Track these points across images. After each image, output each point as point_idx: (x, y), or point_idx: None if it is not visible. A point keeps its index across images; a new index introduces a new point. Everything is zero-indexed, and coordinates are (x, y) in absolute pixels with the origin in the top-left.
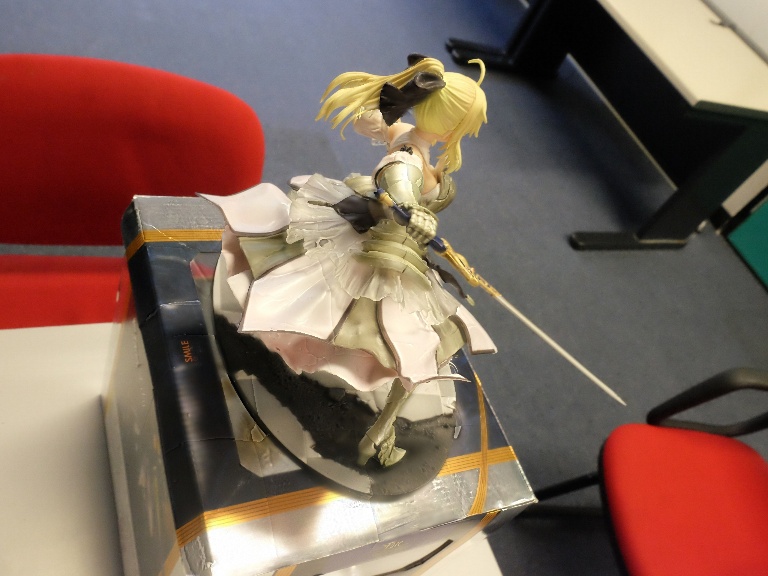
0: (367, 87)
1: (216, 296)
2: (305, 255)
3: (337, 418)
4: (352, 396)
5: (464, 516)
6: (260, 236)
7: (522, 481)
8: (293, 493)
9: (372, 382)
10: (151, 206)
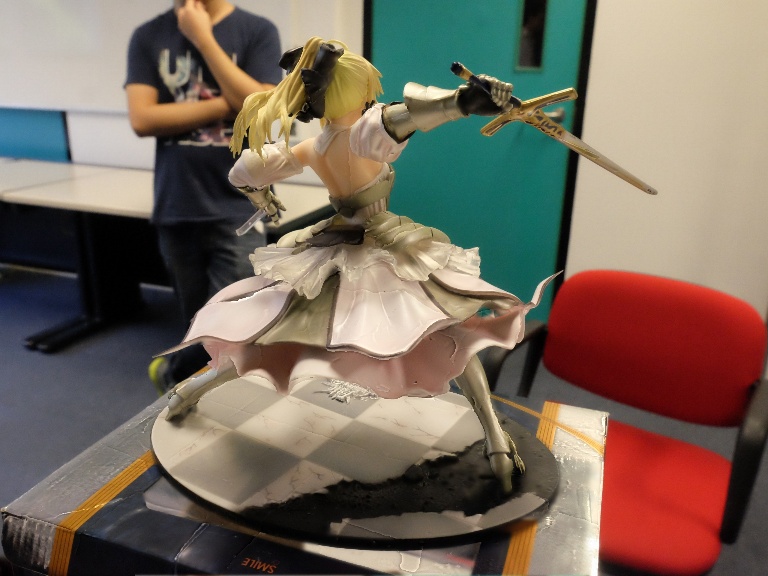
0: (278, 95)
1: (217, 501)
2: (338, 296)
3: (442, 486)
4: (425, 465)
5: (602, 458)
6: (273, 325)
7: (584, 412)
8: (507, 562)
9: (508, 336)
10: (35, 501)
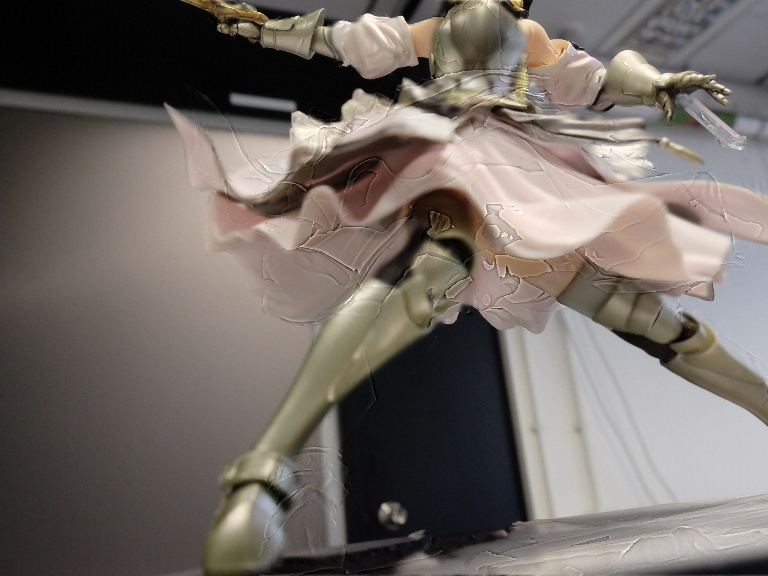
0: None
1: None
2: (396, 230)
3: None
4: None
5: None
6: None
7: None
8: None
9: None
10: None
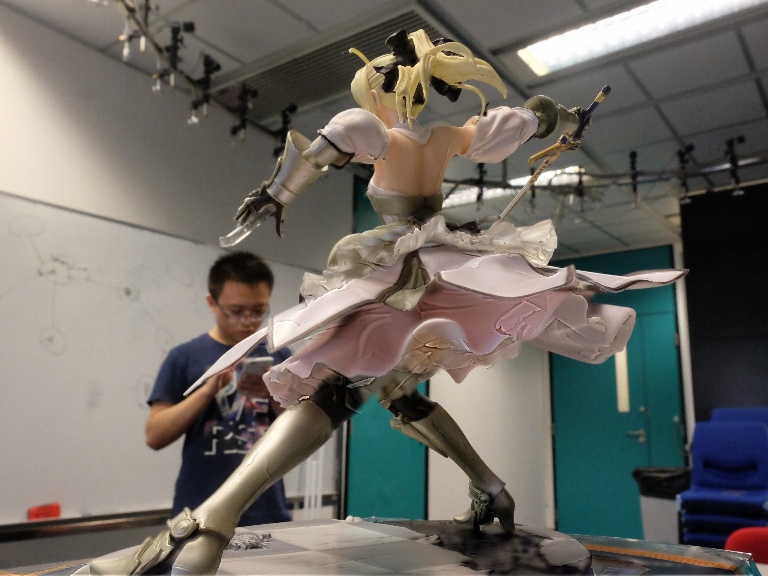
0: None
1: None
2: None
3: (484, 549)
4: None
5: None
6: None
7: None
8: None
9: None
10: None
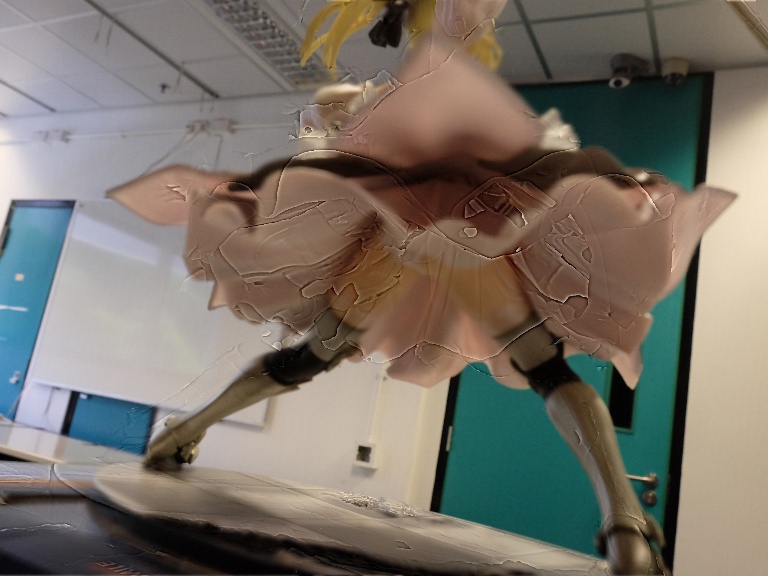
0: None
1: (109, 501)
2: None
3: None
4: (481, 570)
5: None
6: None
7: None
8: None
9: None
10: None
